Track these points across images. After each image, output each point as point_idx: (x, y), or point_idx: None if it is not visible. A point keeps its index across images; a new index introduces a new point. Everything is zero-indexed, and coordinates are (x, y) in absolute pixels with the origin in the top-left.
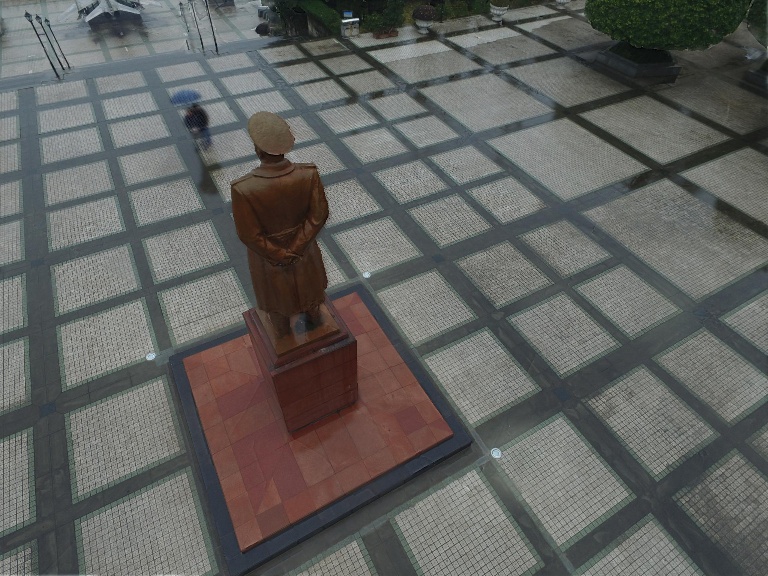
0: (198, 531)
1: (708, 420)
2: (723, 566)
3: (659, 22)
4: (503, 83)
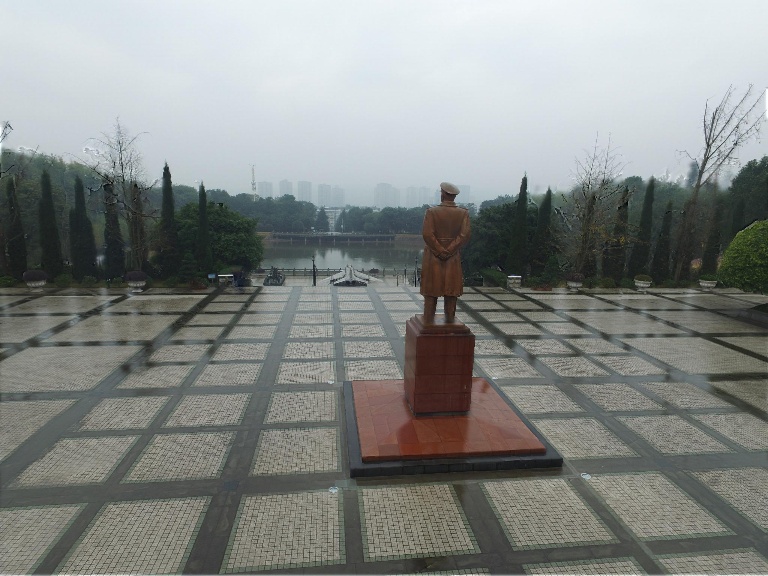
0: (334, 452)
1: None
2: None
3: None
4: (640, 316)
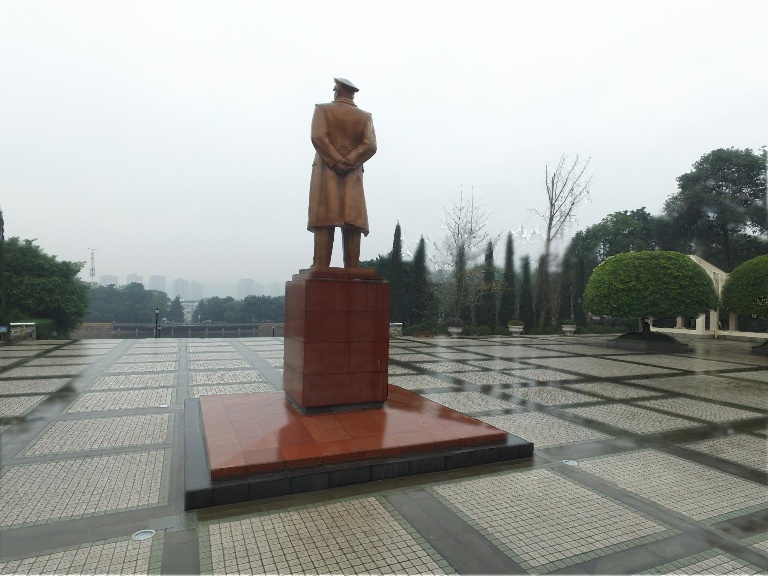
0: (156, 479)
1: None
2: None
3: (645, 298)
4: None
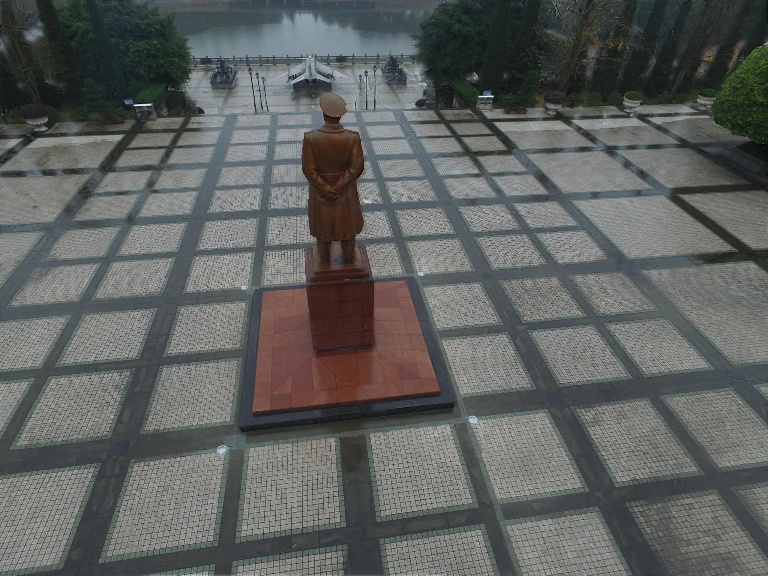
0: (231, 396)
1: (697, 459)
2: (653, 571)
3: None
4: (610, 160)
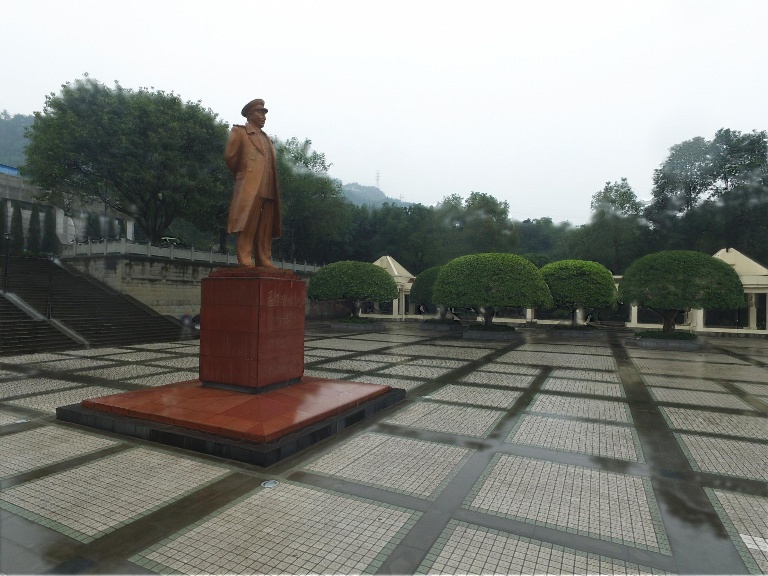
0: None
1: None
2: None
3: None
4: None
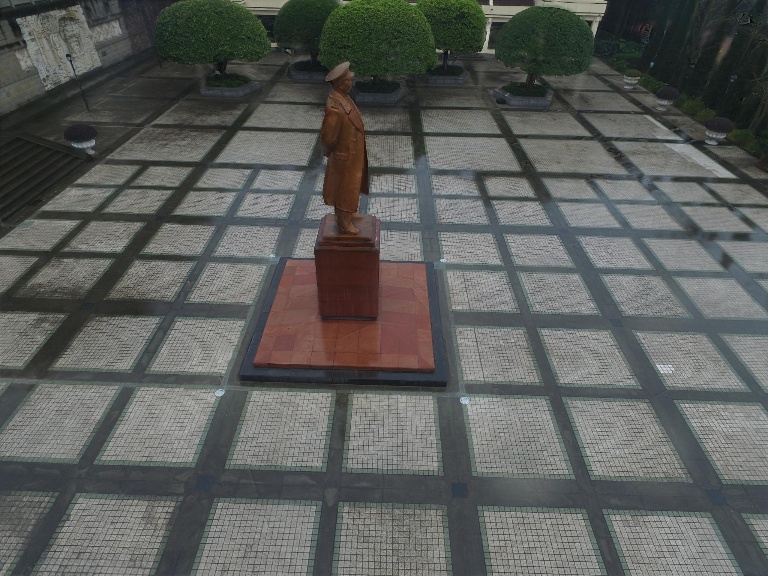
0: None
1: None
2: (3, 481)
3: None
4: None
